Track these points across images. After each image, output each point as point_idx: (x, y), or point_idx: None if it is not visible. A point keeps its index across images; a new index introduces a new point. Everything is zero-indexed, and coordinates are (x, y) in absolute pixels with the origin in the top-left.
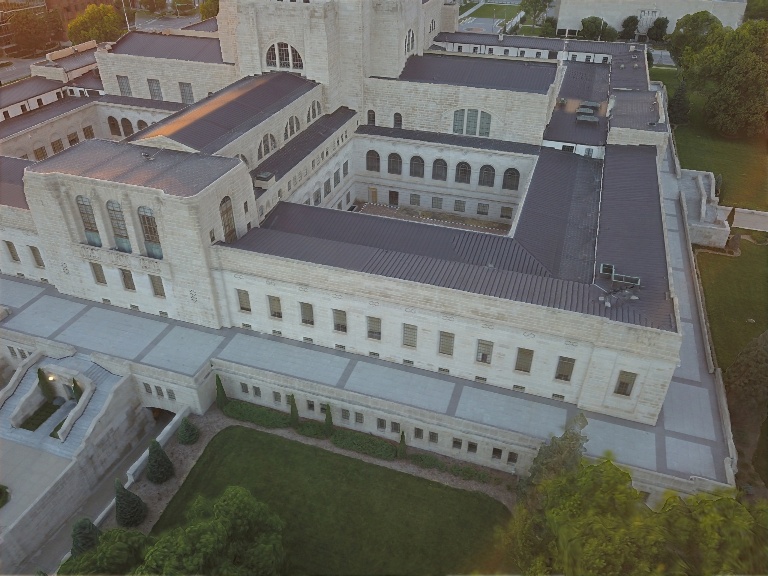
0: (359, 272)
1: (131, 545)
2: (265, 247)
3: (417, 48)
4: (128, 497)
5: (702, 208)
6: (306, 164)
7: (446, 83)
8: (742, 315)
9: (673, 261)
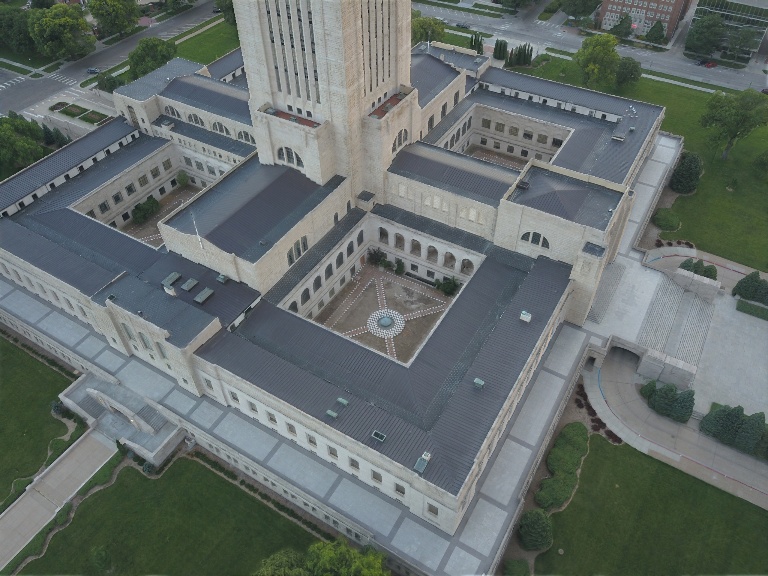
0: (63, 147)
1: (19, 125)
2: (111, 129)
3: (306, 171)
4: (69, 141)
5: (92, 389)
6: (196, 144)
7: (235, 185)
8: (3, 366)
9: (47, 324)
